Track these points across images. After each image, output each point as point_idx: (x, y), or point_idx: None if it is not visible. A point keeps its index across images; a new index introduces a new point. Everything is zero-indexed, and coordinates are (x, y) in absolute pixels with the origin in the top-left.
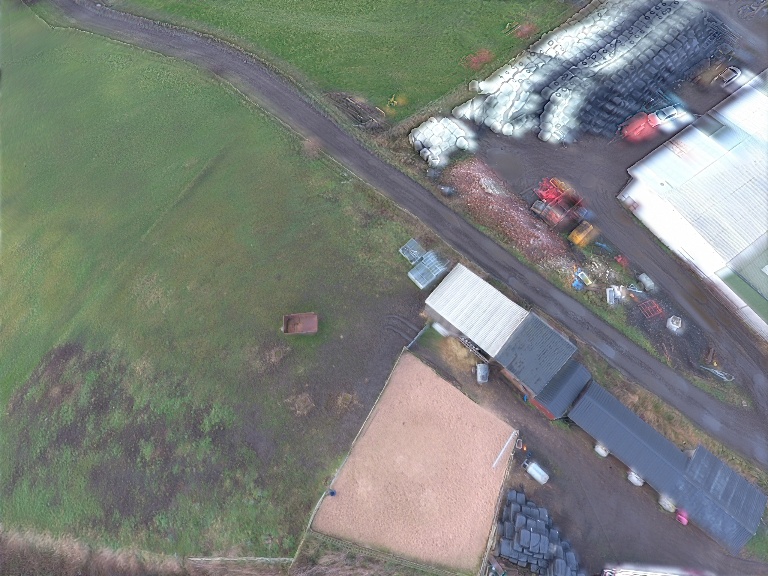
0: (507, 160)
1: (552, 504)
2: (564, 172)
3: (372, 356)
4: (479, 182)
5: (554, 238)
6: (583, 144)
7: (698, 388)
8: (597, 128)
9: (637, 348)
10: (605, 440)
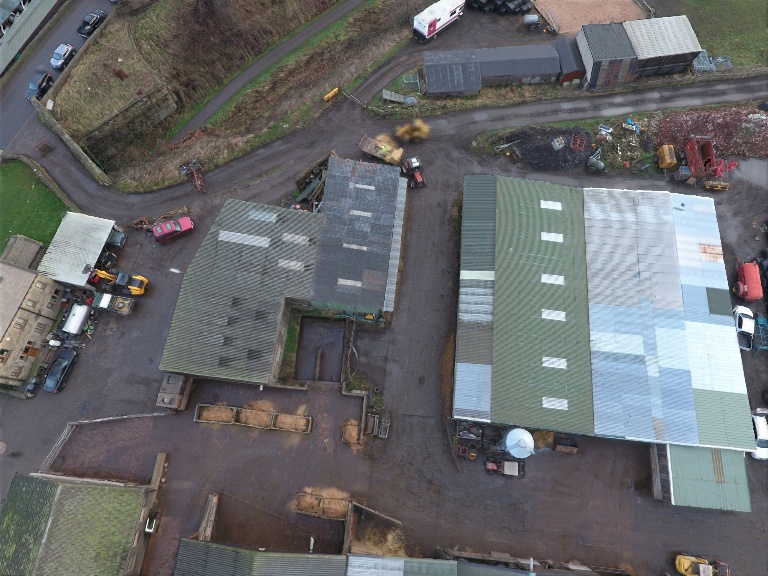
0: (767, 177)
1: (507, 22)
2: (728, 204)
3: (657, 4)
4: (764, 115)
5: (672, 143)
6: (749, 241)
7: (505, 128)
8: (763, 259)
9: (555, 120)
10: (526, 47)
